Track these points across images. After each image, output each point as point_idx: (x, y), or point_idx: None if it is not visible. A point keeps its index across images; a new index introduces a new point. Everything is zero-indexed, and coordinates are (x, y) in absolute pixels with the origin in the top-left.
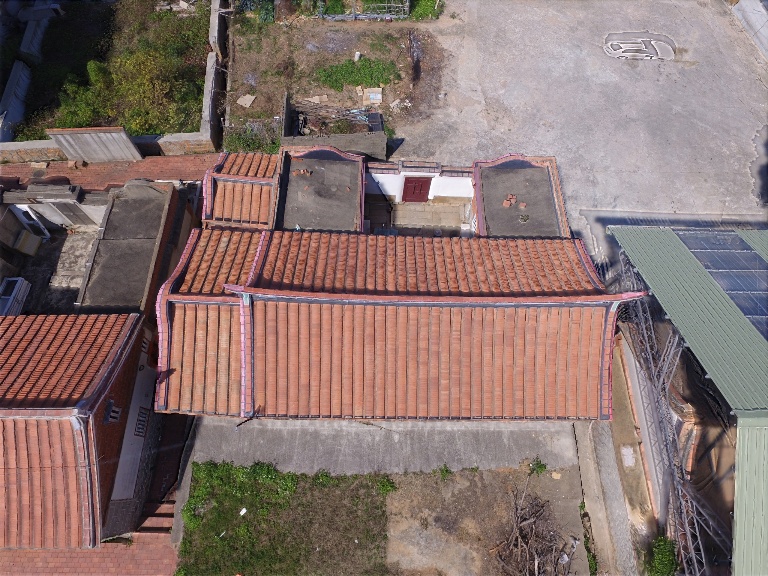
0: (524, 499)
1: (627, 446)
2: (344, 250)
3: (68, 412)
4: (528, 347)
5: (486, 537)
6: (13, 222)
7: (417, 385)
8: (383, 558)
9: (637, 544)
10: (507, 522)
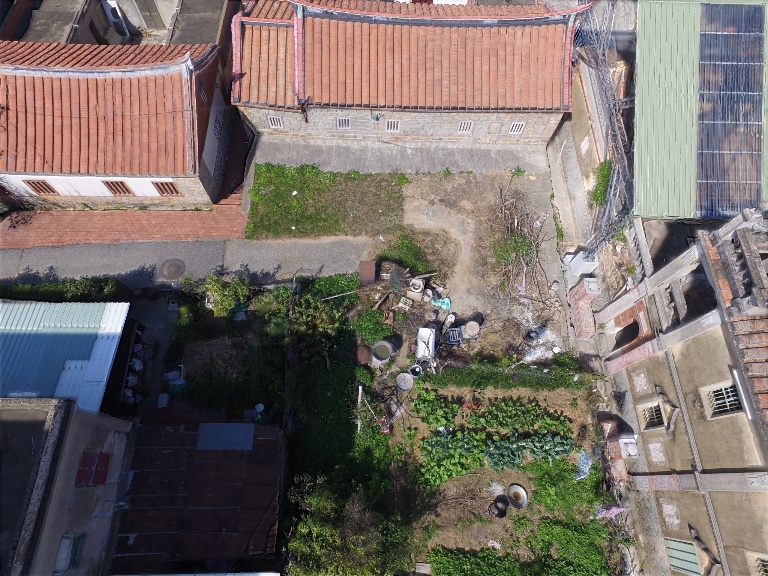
0: (507, 190)
1: (584, 138)
2: (368, 6)
3: (181, 57)
4: (508, 57)
5: (478, 211)
6: (103, 18)
7: (426, 85)
8: (401, 221)
9: (591, 201)
10: (494, 203)
